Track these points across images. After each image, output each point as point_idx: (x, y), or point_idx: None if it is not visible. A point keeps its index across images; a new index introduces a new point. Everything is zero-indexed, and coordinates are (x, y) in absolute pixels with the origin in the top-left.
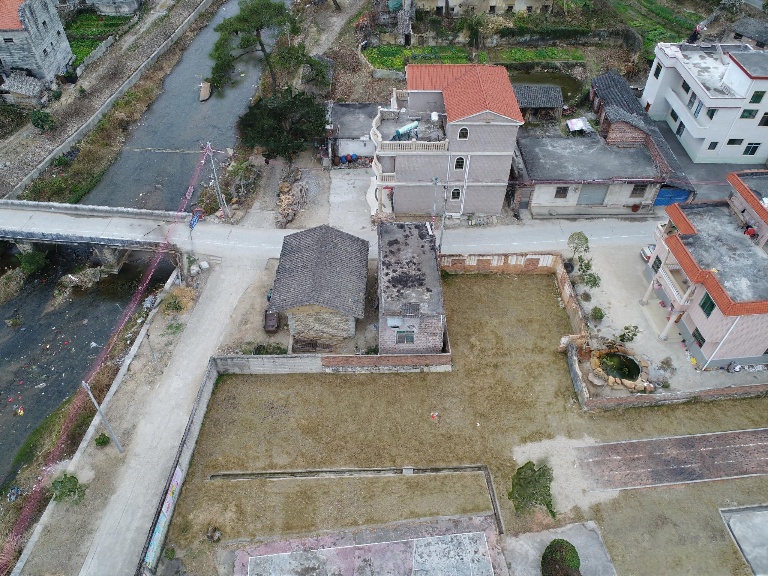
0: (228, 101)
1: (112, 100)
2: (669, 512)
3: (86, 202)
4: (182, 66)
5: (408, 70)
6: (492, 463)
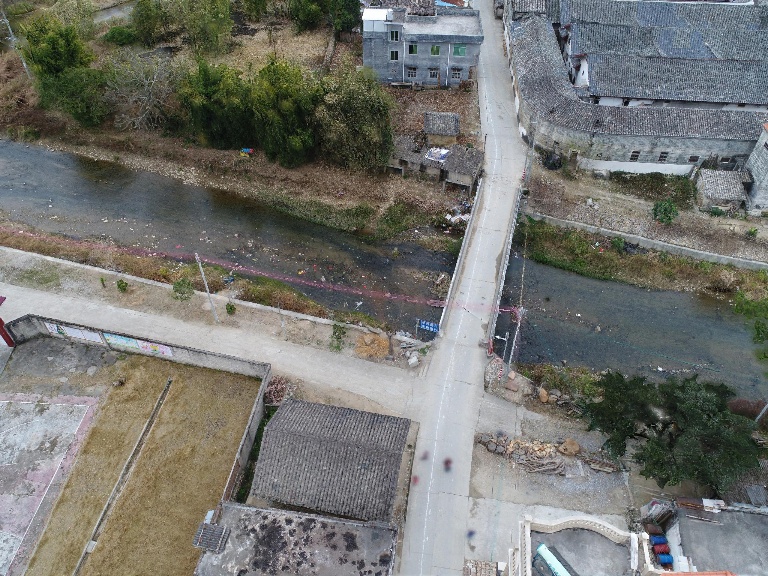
0: None
1: (764, 266)
2: None
3: (562, 274)
4: None
5: (714, 573)
6: None
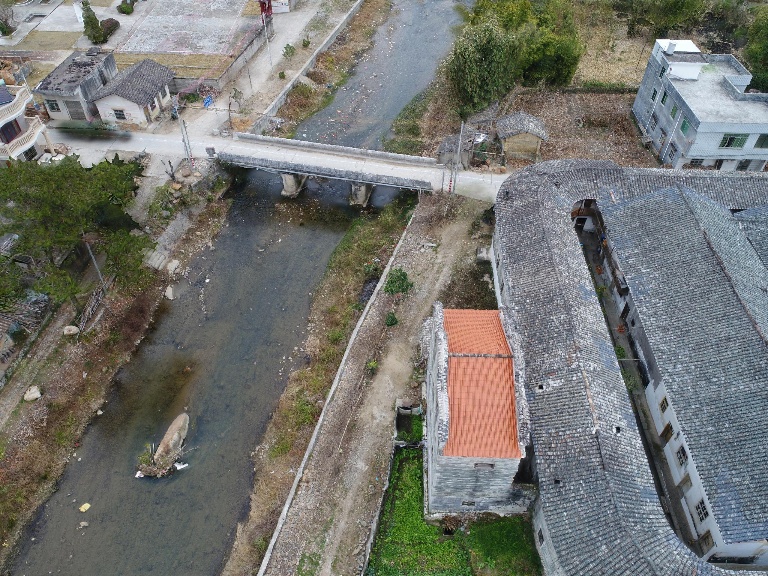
0: (141, 415)
1: None
2: (37, 46)
3: (337, 238)
4: (208, 567)
5: None
6: None
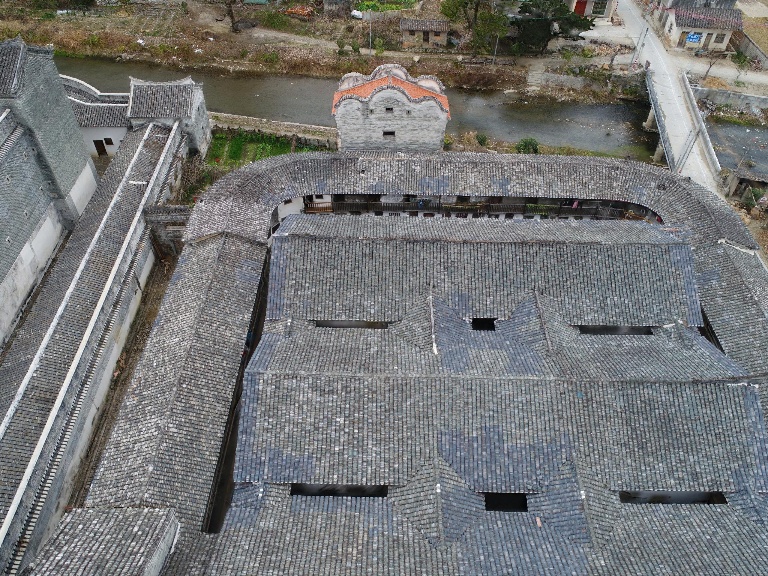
0: None
1: None
2: None
3: None
4: (329, 124)
5: None
6: (761, 20)
